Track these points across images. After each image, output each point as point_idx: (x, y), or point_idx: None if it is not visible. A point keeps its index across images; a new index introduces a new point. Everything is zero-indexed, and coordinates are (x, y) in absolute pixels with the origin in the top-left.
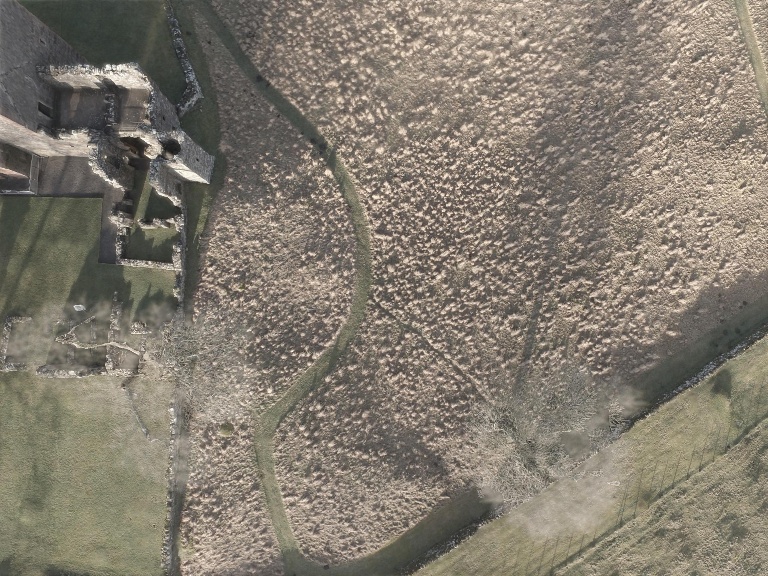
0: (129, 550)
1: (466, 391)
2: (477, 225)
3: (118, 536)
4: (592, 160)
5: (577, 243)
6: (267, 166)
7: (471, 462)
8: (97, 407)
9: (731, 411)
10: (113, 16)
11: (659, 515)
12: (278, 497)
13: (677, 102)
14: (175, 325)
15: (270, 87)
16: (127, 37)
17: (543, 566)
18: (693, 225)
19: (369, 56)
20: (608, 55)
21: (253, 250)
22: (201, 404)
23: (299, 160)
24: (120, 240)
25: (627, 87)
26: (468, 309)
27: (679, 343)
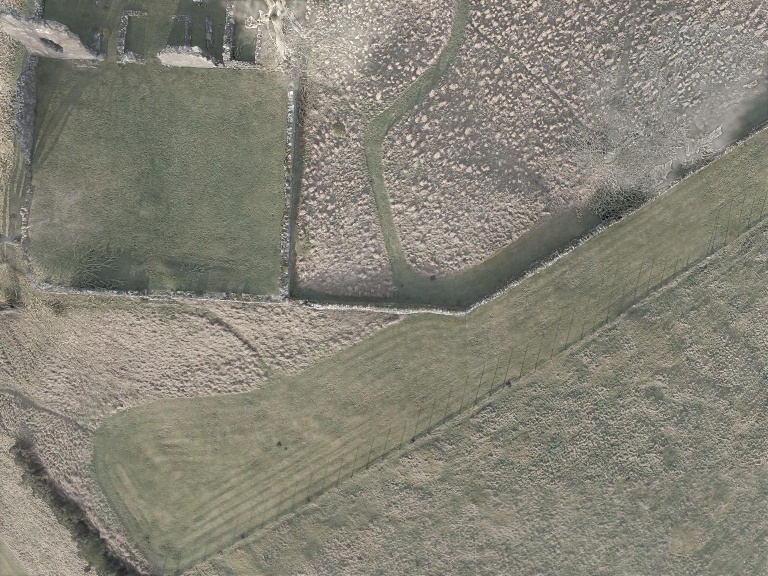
0: (248, 240)
1: (563, 115)
2: None
3: (237, 226)
4: None
5: None
6: None
7: (570, 181)
8: (214, 101)
9: None
10: None
11: (748, 246)
12: (387, 204)
13: None
14: None
15: None
16: None
17: (639, 287)
18: None
19: None
20: None
21: None
22: (314, 102)
23: None
24: None
25: None
26: (563, 38)
27: (764, 83)
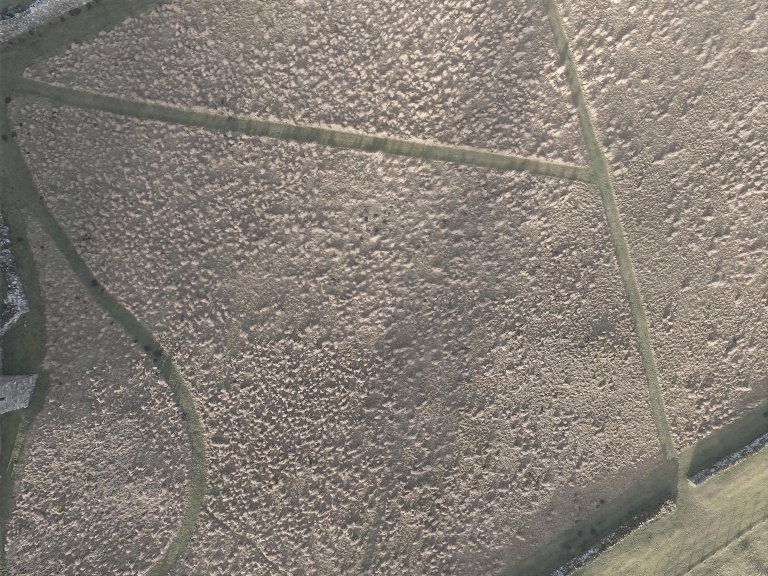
0: None
1: None
2: (319, 430)
3: None
4: (443, 360)
5: (423, 448)
6: (94, 381)
7: None
8: None
9: None
10: None
11: None
12: None
13: (535, 298)
14: None
15: (105, 292)
16: None
17: None
18: (549, 424)
19: (211, 256)
20: (463, 251)
21: (75, 470)
22: None
23: (130, 371)
24: None
25: (483, 283)
26: (306, 518)
27: (530, 546)
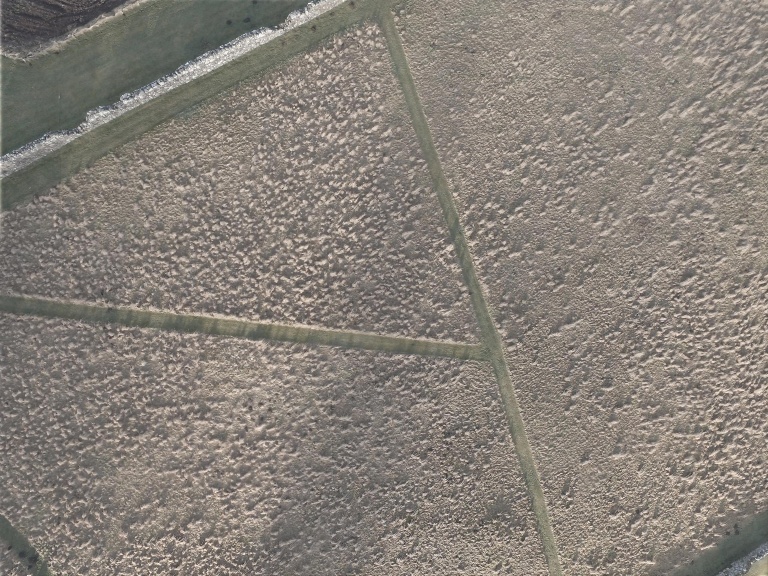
0: None
1: None
2: None
3: None
4: (331, 551)
5: None
6: None
7: None
8: None
9: None
10: None
11: None
12: None
13: (427, 482)
14: None
15: None
16: None
17: None
18: None
19: (90, 453)
20: (352, 437)
21: None
22: None
23: None
24: None
25: (372, 469)
26: None
27: None
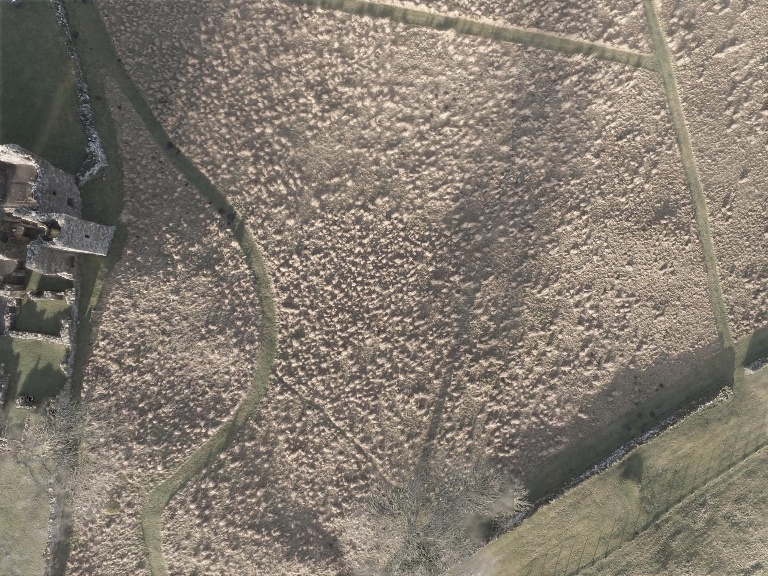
0: None
1: (367, 470)
2: (387, 300)
3: None
4: (509, 237)
5: (489, 322)
6: (170, 237)
7: (367, 544)
8: None
9: (641, 496)
10: (19, 79)
11: None
12: (165, 575)
13: (599, 181)
14: (59, 402)
15: (180, 154)
16: (32, 101)
17: None
18: (611, 306)
19: (285, 125)
20: (531, 131)
21: (150, 323)
22: (86, 481)
23: (205, 231)
24: (9, 312)
25: (549, 164)
26: (373, 386)
27: (591, 425)
